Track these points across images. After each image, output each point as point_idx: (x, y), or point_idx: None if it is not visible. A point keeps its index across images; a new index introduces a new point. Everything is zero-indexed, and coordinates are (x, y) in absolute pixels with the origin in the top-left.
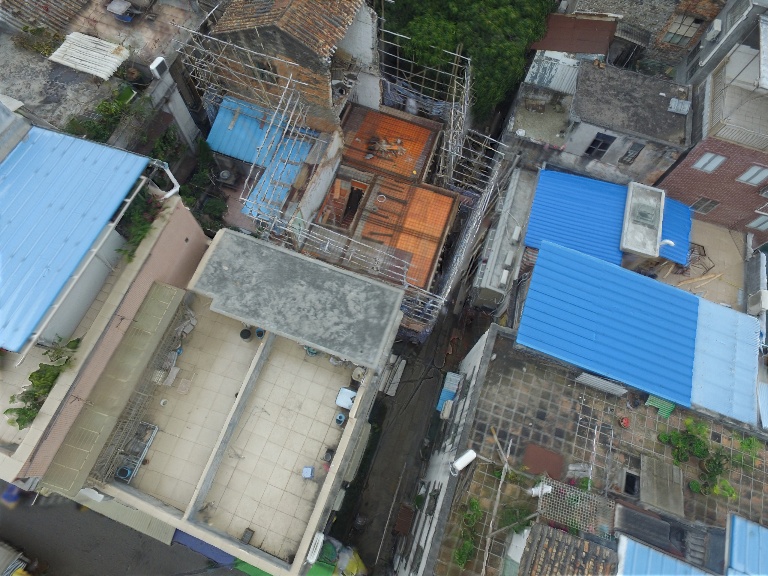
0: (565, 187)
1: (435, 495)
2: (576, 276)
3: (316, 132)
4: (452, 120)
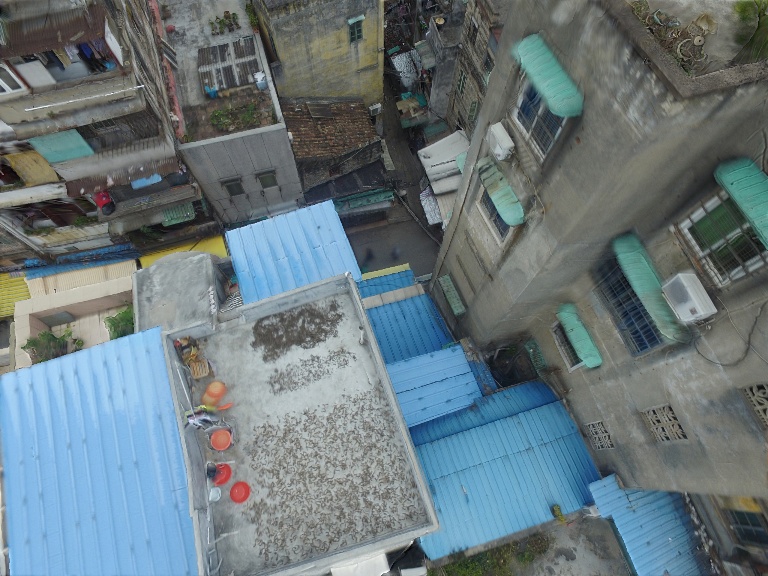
0: None
1: None
2: None
3: None
4: None
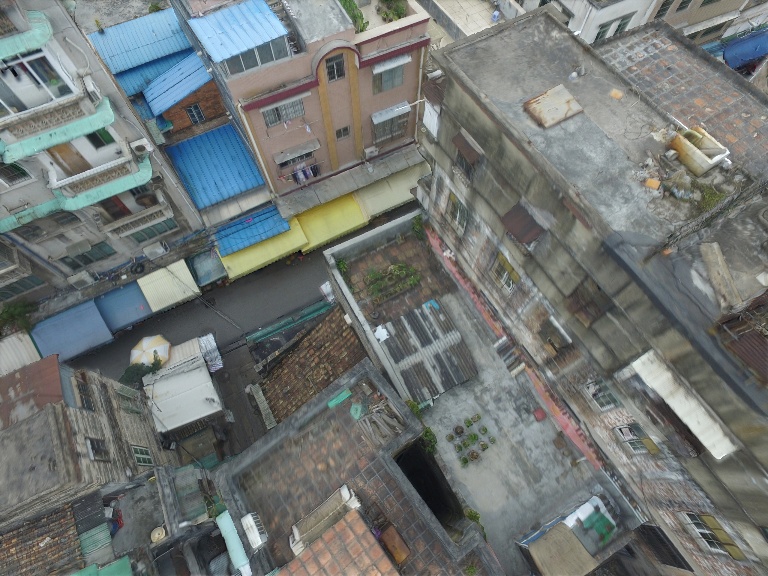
0: None
1: None
2: None
3: None
4: None
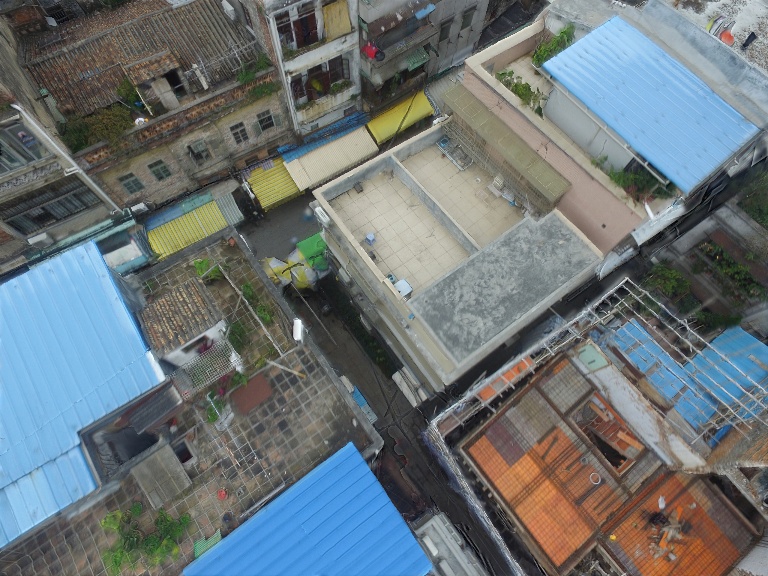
0: None
1: None
2: (372, 569)
3: (715, 445)
4: None
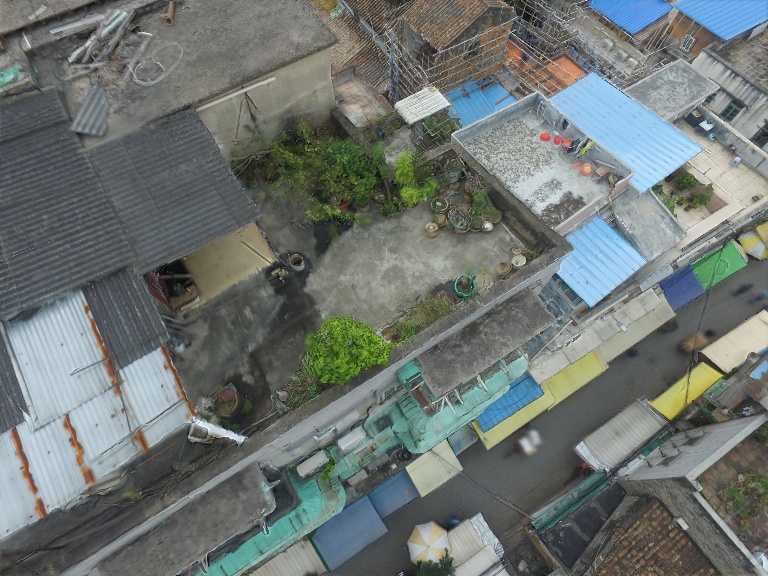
0: (608, 0)
1: (763, 130)
2: (701, 5)
3: None
4: (546, 9)
